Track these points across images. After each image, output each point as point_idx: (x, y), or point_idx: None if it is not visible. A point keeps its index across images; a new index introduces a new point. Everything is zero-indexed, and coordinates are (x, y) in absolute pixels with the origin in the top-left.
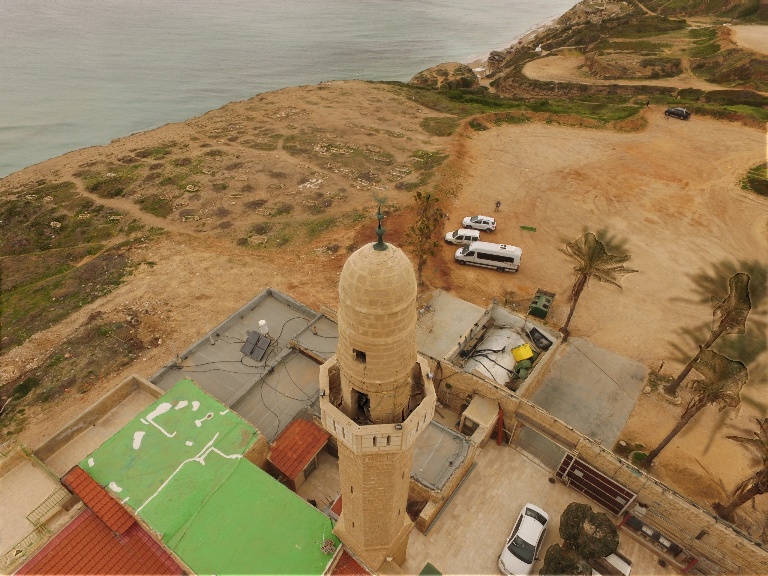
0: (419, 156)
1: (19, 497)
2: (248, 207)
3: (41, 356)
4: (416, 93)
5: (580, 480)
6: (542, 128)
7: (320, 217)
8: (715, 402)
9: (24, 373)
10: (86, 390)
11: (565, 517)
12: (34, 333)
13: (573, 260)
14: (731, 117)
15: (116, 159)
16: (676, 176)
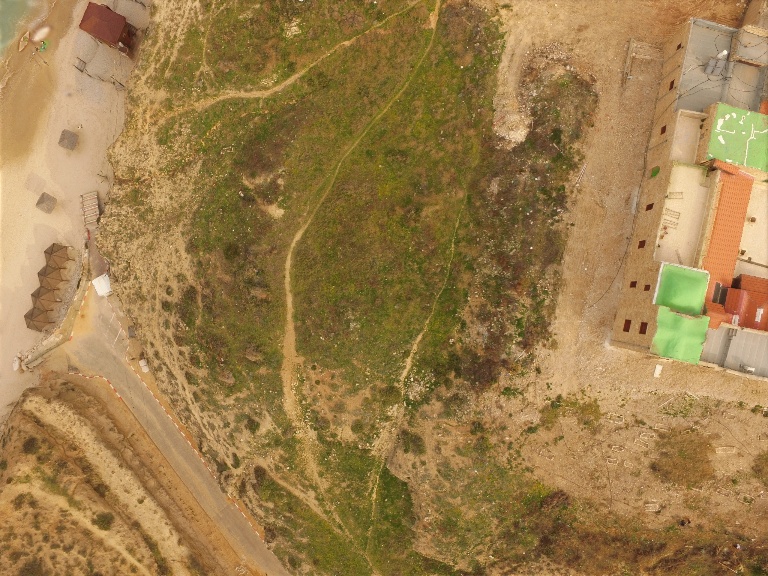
0: None
1: (683, 178)
2: None
3: (522, 113)
4: None
5: None
6: None
7: None
8: None
9: (531, 127)
10: (593, 124)
11: None
12: (492, 99)
13: None
14: None
15: None
16: None
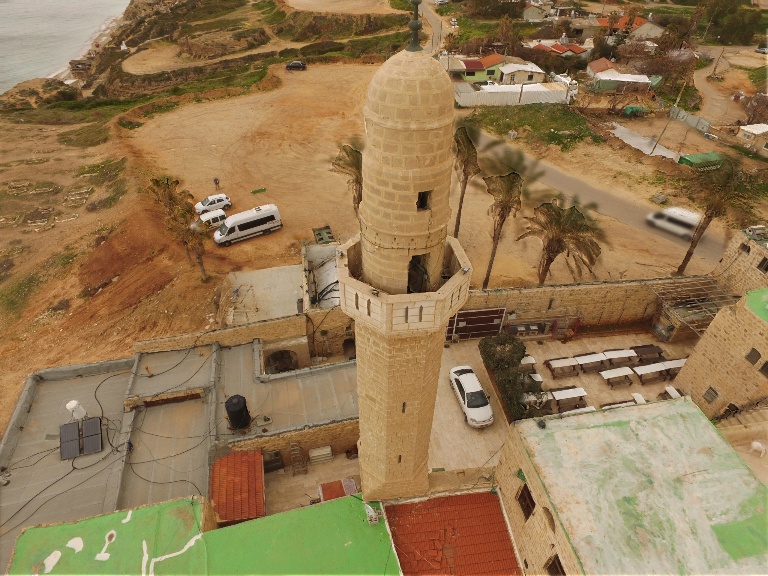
0: (88, 171)
1: None
2: None
3: None
4: (20, 115)
5: (465, 329)
6: (196, 108)
7: (9, 284)
8: (510, 212)
9: None
10: None
11: (484, 353)
12: None
13: (344, 175)
14: (333, 60)
15: None
16: (332, 111)
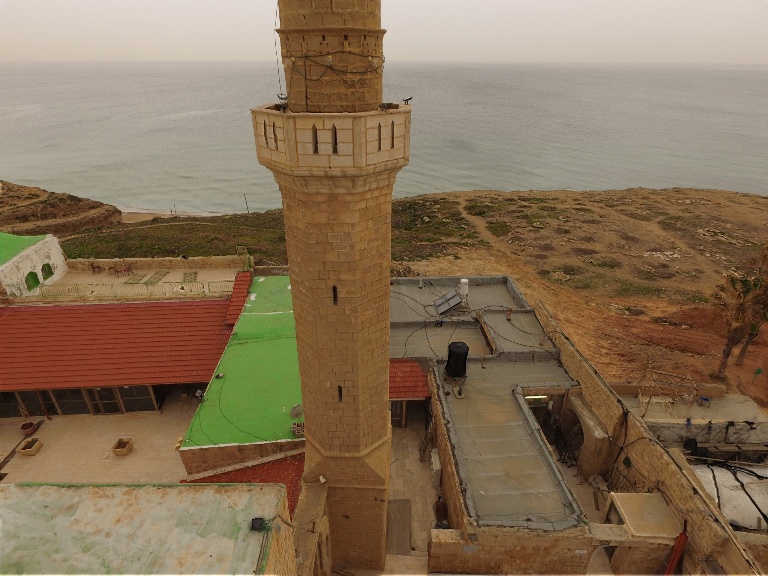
0: None
1: None
2: (575, 251)
3: None
4: None
5: None
6: None
7: (646, 283)
8: None
9: None
10: None
11: None
12: None
13: None
14: None
15: (502, 198)
16: None
